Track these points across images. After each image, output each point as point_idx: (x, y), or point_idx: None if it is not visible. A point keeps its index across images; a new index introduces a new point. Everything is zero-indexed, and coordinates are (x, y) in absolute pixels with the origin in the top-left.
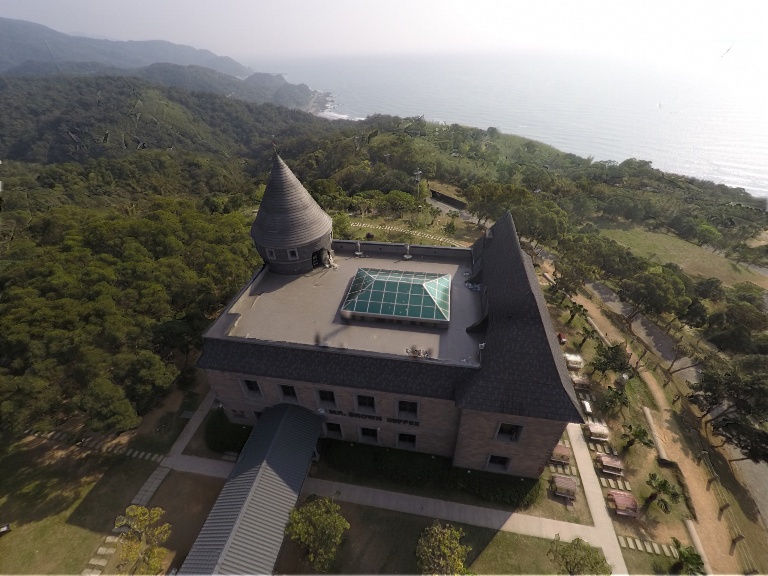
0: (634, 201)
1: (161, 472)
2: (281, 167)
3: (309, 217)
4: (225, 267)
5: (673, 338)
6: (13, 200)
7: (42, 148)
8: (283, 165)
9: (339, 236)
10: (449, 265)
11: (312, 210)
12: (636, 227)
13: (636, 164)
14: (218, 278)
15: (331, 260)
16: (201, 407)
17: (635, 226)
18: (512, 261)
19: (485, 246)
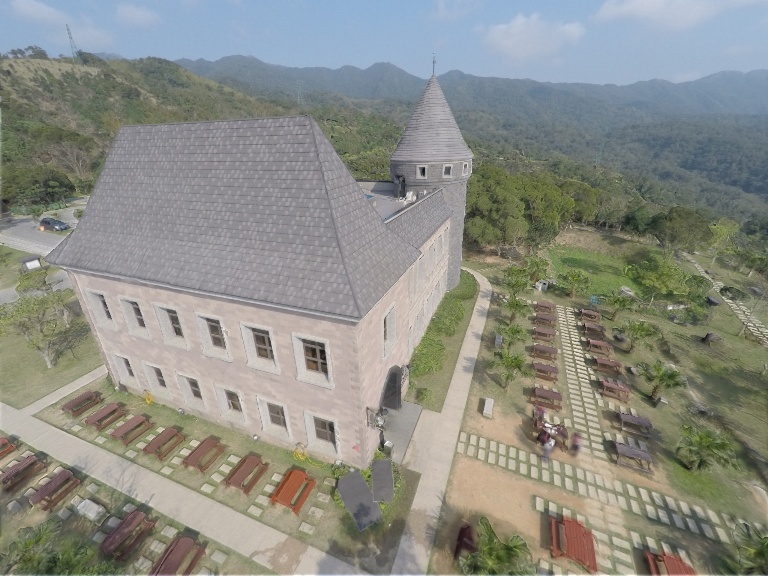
0: None
1: None
2: None
3: (411, 139)
4: None
5: None
6: None
7: None
8: (431, 83)
9: (686, 316)
10: None
11: (419, 134)
12: None
13: None
14: None
15: (408, 197)
16: None
17: None
18: None
19: None
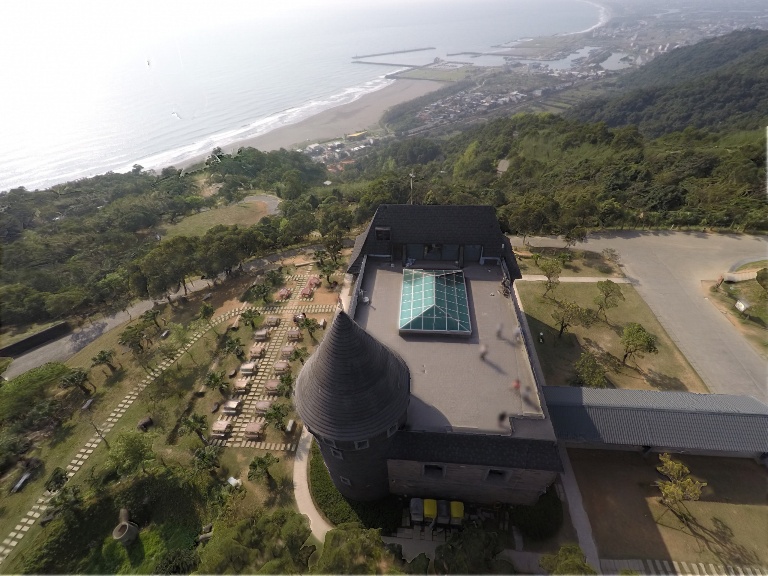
0: (137, 212)
1: (609, 570)
2: (351, 320)
3: None
4: (355, 558)
5: (345, 239)
6: None
7: None
8: None
9: None
10: (378, 275)
11: None
12: (163, 228)
13: (21, 196)
14: (375, 571)
15: None
16: (525, 569)
17: (159, 228)
18: (446, 214)
19: (391, 236)
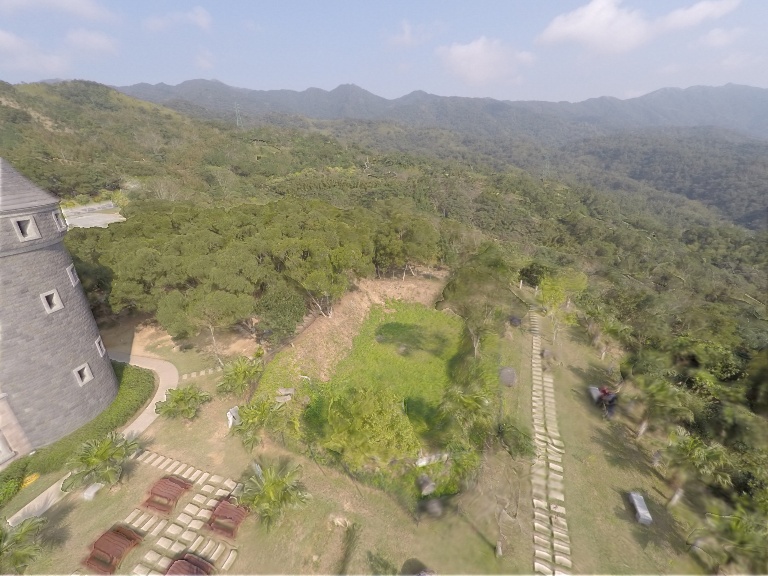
0: None
1: None
2: None
3: None
4: None
5: None
6: (621, 236)
7: (746, 212)
8: None
9: (453, 475)
10: None
11: None
12: None
13: None
14: None
15: None
16: None
17: None
18: None
19: None
